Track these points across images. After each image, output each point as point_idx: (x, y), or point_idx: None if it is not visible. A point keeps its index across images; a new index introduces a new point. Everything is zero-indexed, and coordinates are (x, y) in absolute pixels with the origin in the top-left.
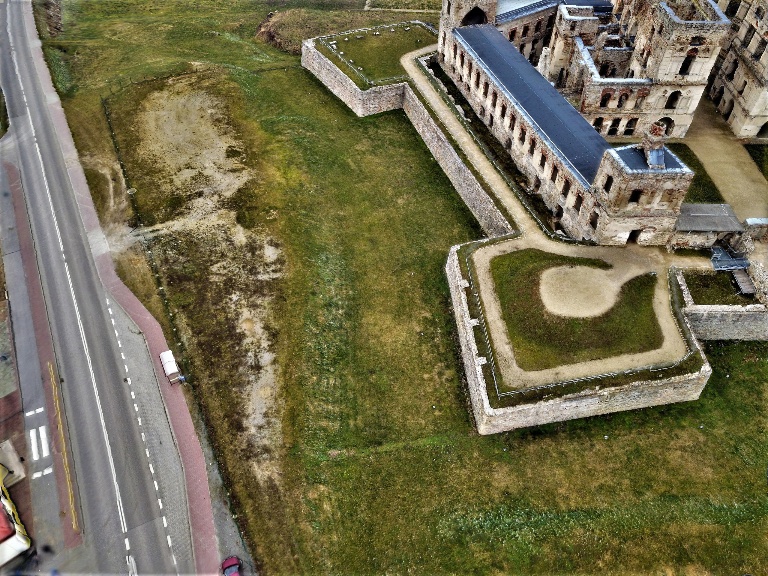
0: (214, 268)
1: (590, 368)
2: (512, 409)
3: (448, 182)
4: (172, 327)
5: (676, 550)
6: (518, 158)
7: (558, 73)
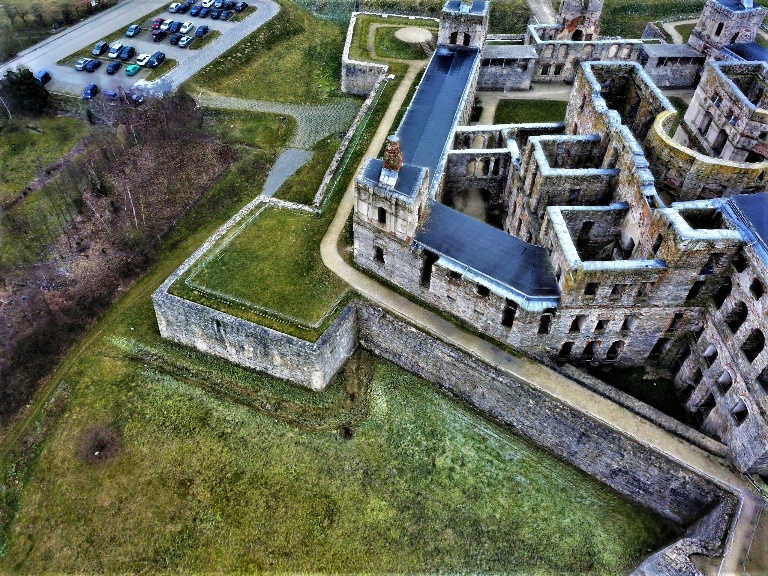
0: None
1: None
2: None
3: None
4: None
5: None
6: None
7: None
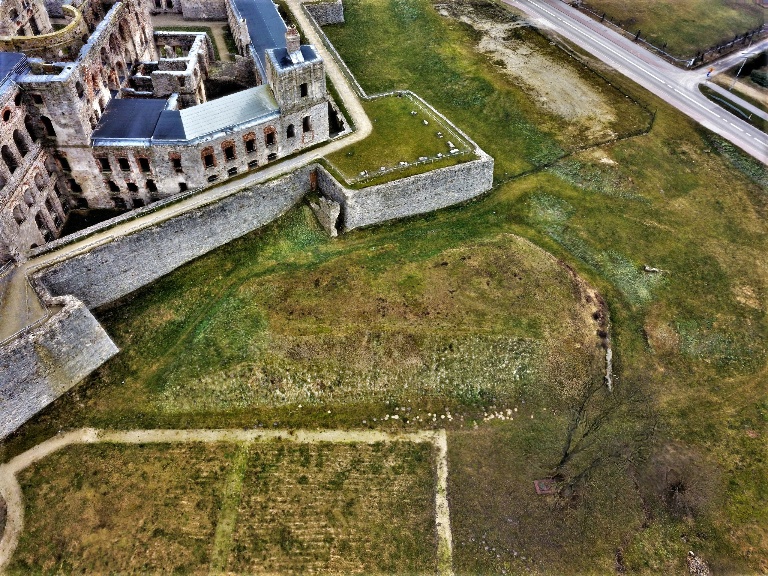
0: (472, 8)
1: None
2: None
3: None
4: None
5: None
6: None
7: None
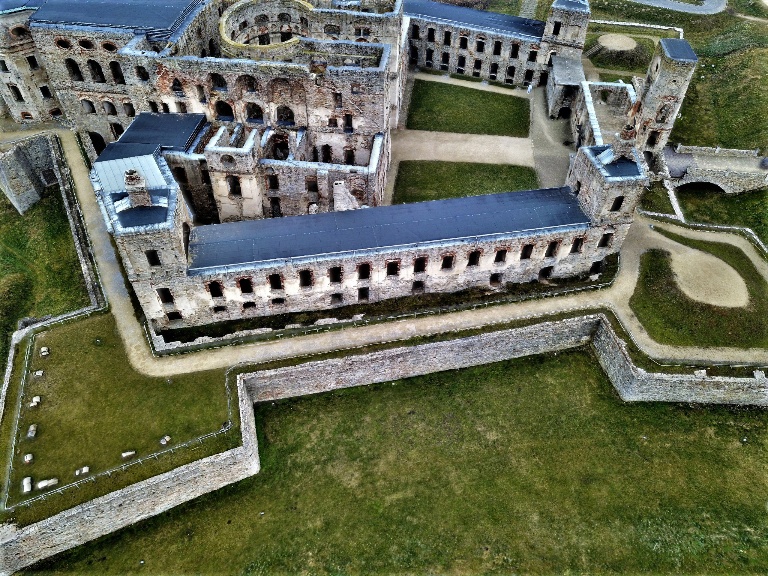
0: None
1: None
2: None
3: (450, 373)
4: None
5: None
6: (447, 285)
7: (261, 209)
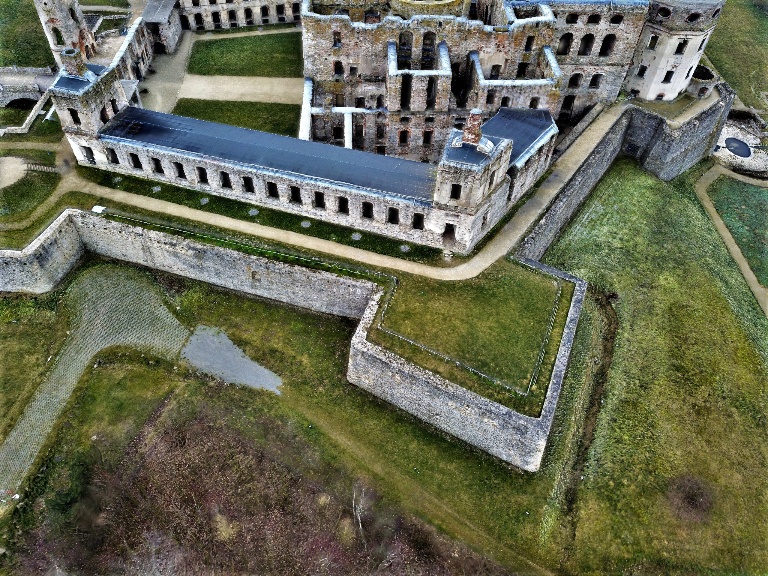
0: None
1: None
2: None
3: None
4: None
5: None
6: None
7: None
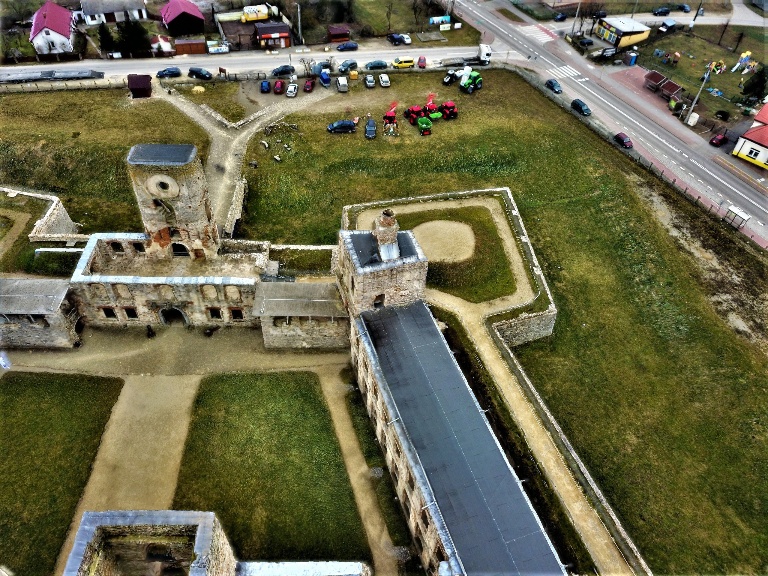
0: None
1: (436, 205)
2: (492, 189)
3: None
4: (766, 255)
5: (401, 148)
6: None
7: None
